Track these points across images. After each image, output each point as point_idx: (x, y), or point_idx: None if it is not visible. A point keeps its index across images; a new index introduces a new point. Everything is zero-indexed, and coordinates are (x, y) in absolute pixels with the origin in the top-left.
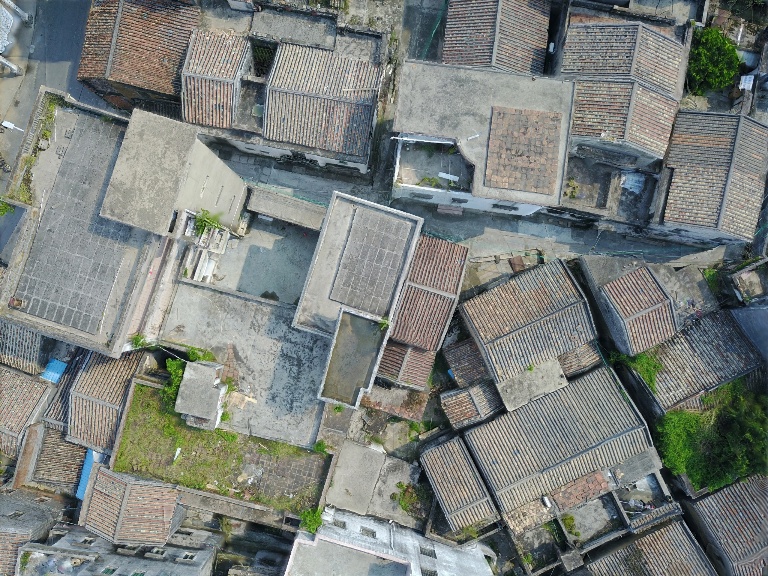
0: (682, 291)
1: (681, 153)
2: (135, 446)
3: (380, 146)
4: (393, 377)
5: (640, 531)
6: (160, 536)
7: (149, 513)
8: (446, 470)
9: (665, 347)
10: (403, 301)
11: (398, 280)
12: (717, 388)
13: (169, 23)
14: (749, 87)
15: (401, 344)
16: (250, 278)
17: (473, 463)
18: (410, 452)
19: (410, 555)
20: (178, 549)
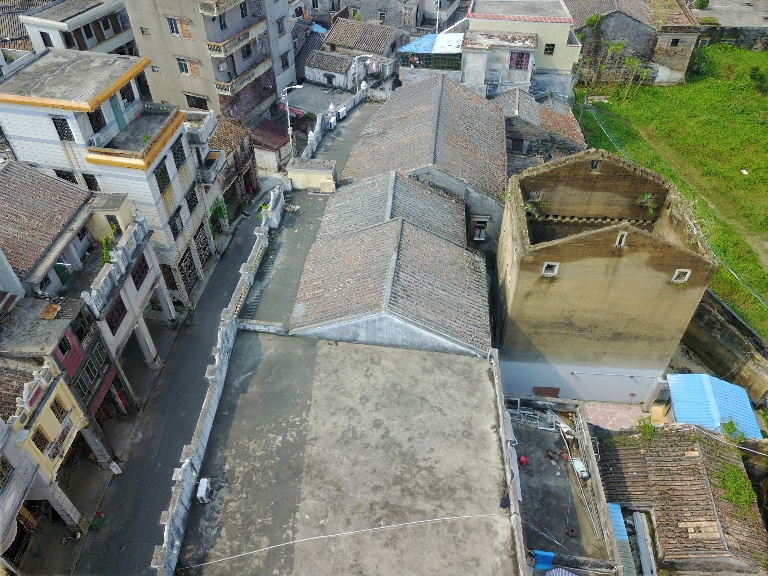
0: None
1: None
2: None
3: None
4: None
5: None
6: None
7: None
8: None
9: None
10: None
11: None
12: None
13: None
14: None
15: None
16: None
17: None
18: None
19: None
20: None
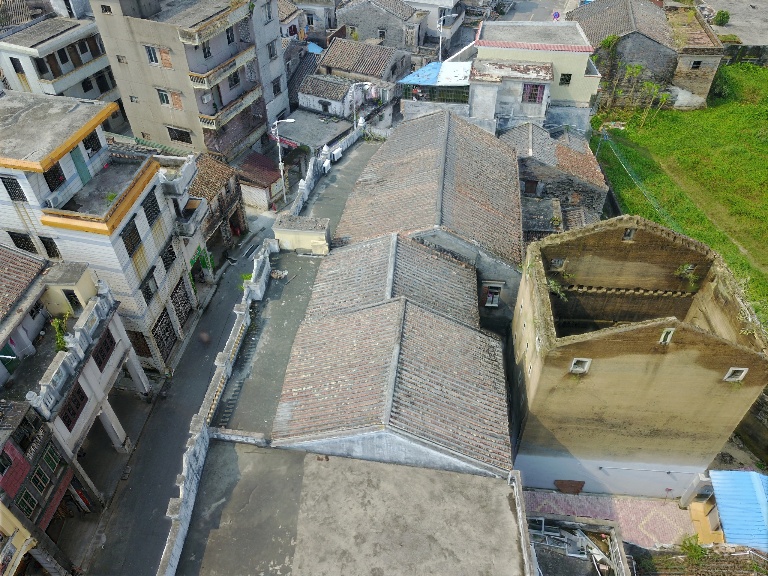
0: None
1: None
2: None
3: None
4: None
5: None
6: None
7: None
8: None
9: None
10: None
11: None
12: None
13: None
14: None
15: None
16: None
17: None
18: None
19: None
20: None
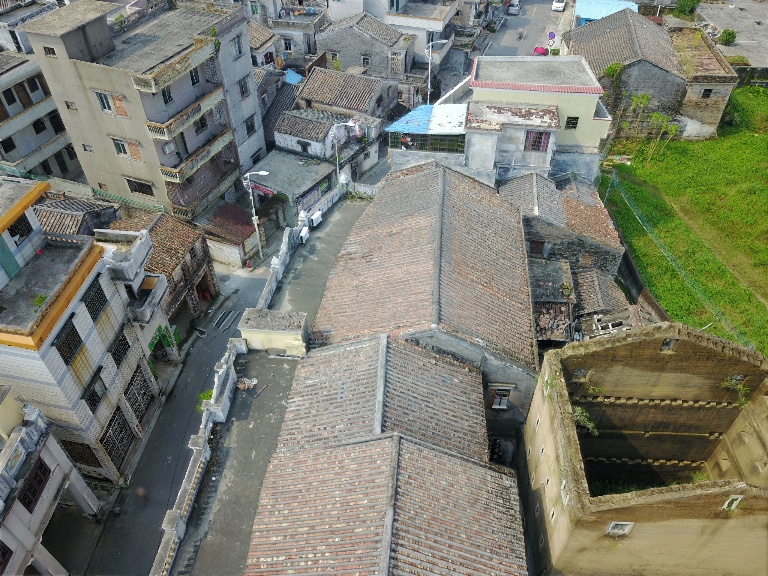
0: None
1: None
2: None
3: None
4: None
5: None
6: None
7: None
8: None
9: None
10: None
11: None
12: None
13: None
14: None
15: None
16: None
17: None
18: None
19: None
20: None
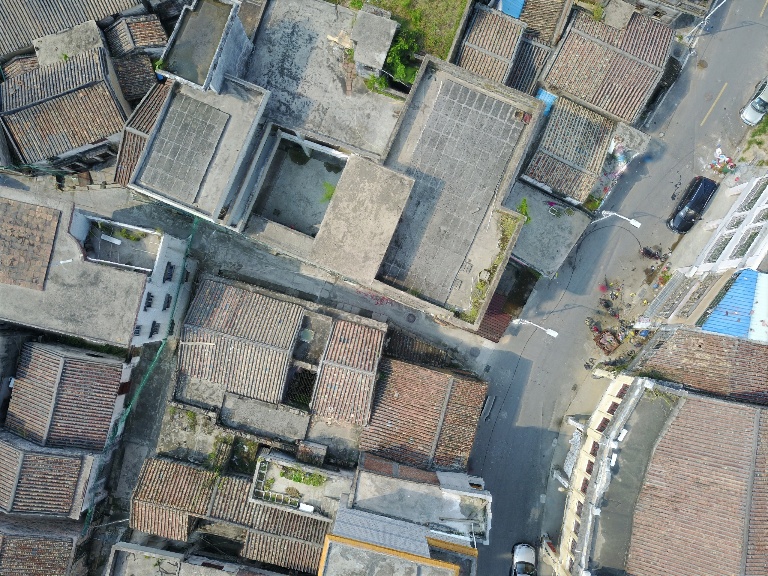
0: None
1: None
2: (452, 4)
3: None
4: None
5: None
6: None
7: None
8: None
9: None
10: None
11: (160, 128)
12: None
13: (390, 434)
14: None
15: None
16: None
17: None
18: None
19: None
20: None
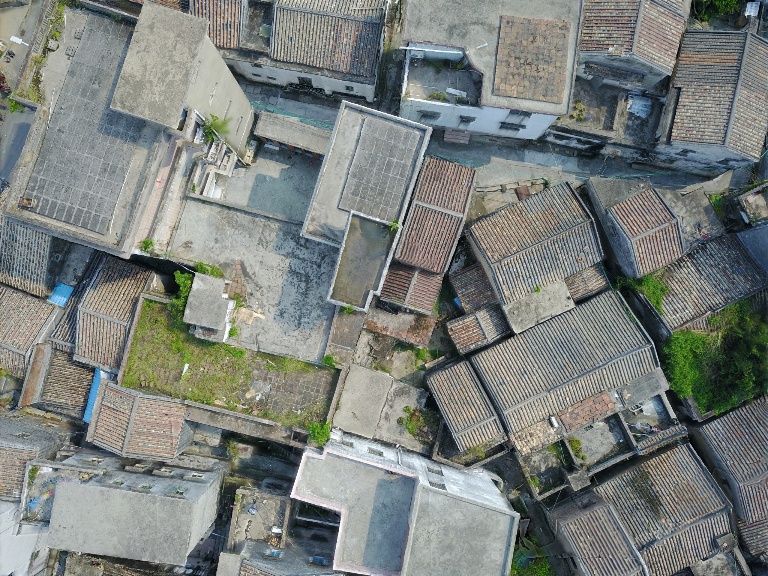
0: (688, 216)
1: (688, 73)
2: (143, 362)
3: (386, 75)
4: (400, 300)
5: (647, 452)
6: (168, 451)
7: (157, 428)
8: (453, 392)
9: (671, 271)
10: (410, 221)
11: (407, 190)
12: (724, 309)
13: None
14: (755, 13)
15: (408, 267)
16: (256, 207)
17: (480, 384)
18: (416, 381)
19: (418, 471)
20: (185, 470)
